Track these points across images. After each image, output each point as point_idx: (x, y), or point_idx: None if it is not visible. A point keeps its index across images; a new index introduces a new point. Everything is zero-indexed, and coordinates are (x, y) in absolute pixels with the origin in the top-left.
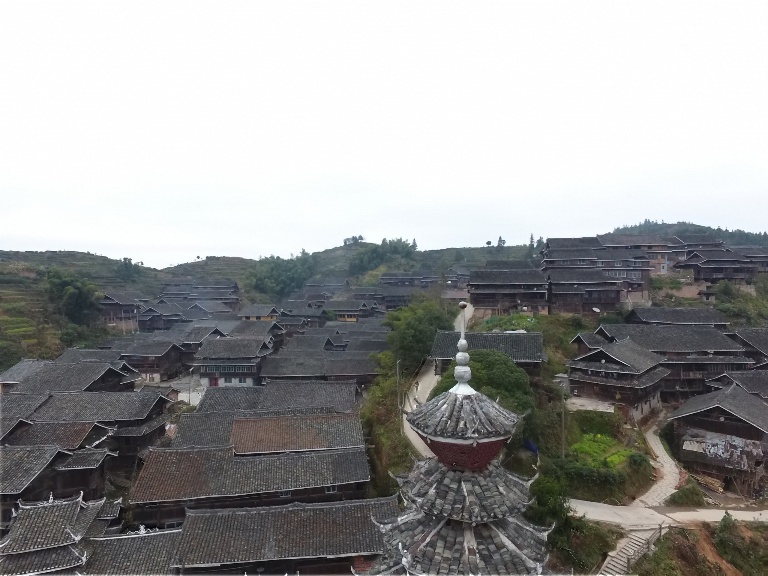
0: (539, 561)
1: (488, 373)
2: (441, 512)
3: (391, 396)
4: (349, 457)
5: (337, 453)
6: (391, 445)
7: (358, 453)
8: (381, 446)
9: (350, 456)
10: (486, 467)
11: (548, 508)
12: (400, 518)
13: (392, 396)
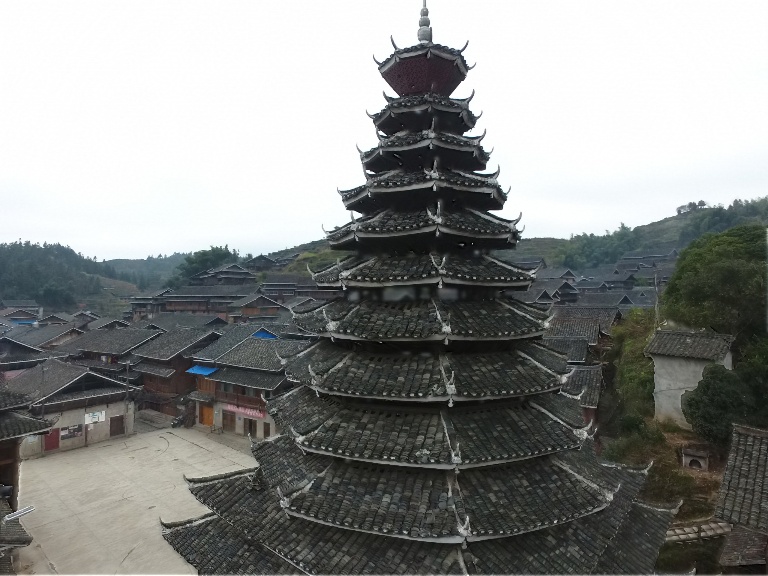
0: (430, 128)
1: (747, 246)
2: None
3: (651, 313)
4: (568, 343)
5: (557, 339)
6: (631, 349)
7: (579, 341)
8: (623, 353)
9: (569, 342)
10: (427, 93)
11: None
12: None
13: (652, 313)
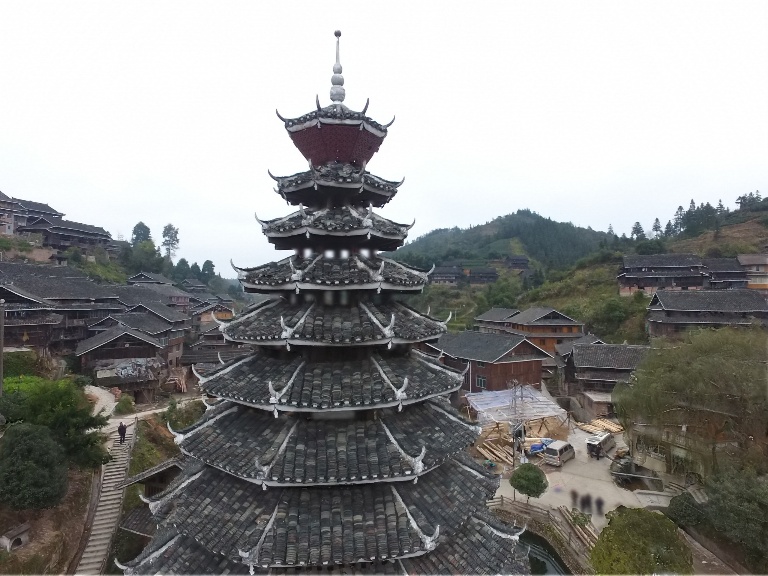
0: None
1: None
2: (378, 185)
3: None
4: None
5: None
6: None
7: None
8: None
9: None
10: None
11: (71, 408)
12: (314, 213)
13: None
